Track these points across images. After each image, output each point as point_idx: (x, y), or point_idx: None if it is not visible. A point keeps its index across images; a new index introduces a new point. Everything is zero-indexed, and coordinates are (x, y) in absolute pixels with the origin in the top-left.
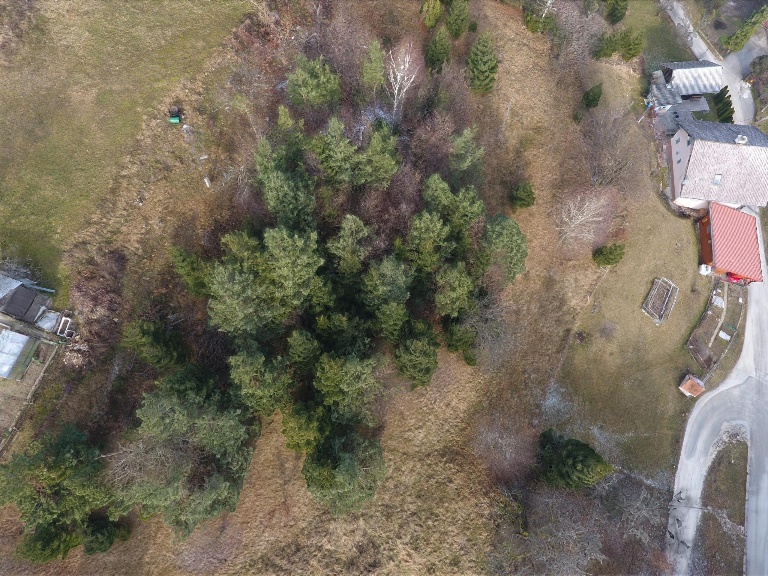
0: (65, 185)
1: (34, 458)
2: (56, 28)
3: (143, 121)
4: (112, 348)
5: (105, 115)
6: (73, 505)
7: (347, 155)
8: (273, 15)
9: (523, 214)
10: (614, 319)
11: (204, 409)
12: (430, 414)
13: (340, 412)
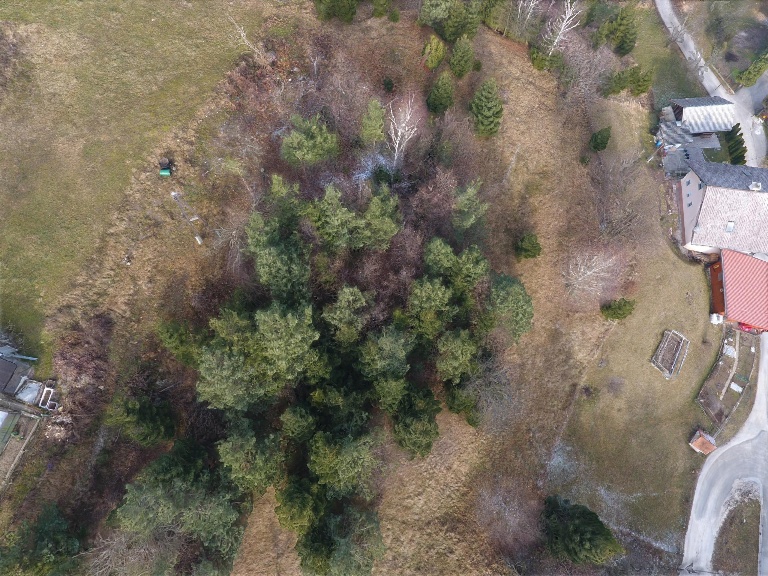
0: (49, 245)
1: (9, 556)
2: (42, 74)
3: (132, 174)
4: (97, 418)
5: (92, 168)
6: None
7: (344, 219)
8: (269, 56)
9: (528, 263)
10: (622, 373)
11: (192, 493)
12: (430, 479)
13: (336, 489)
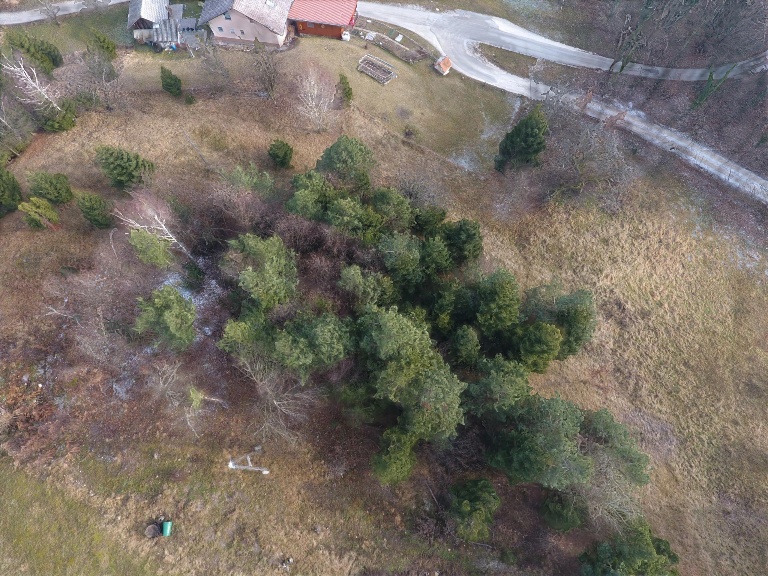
0: None
1: None
2: None
3: (166, 574)
4: (469, 574)
5: None
6: (654, 567)
7: None
8: None
9: (295, 160)
10: (393, 106)
11: None
12: None
13: None
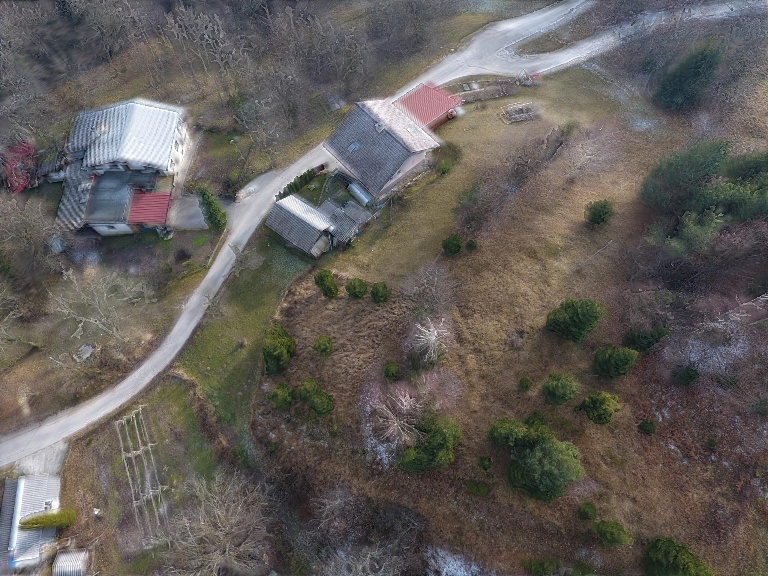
0: None
1: None
2: None
3: None
4: None
5: None
6: None
7: None
8: None
9: None
10: (557, 127)
11: None
12: None
13: None
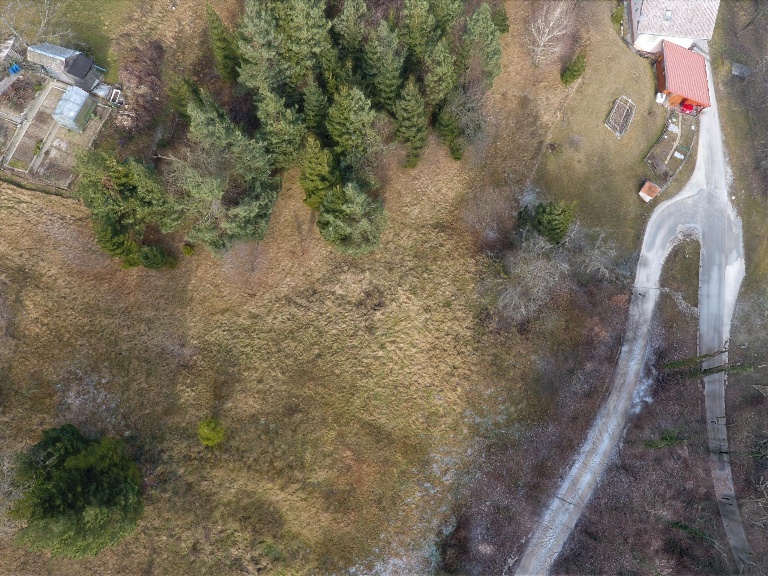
0: None
1: None
2: None
3: None
4: (155, 120)
5: None
6: (135, 206)
7: None
8: None
9: None
10: (581, 132)
11: None
12: (423, 195)
13: (348, 162)
